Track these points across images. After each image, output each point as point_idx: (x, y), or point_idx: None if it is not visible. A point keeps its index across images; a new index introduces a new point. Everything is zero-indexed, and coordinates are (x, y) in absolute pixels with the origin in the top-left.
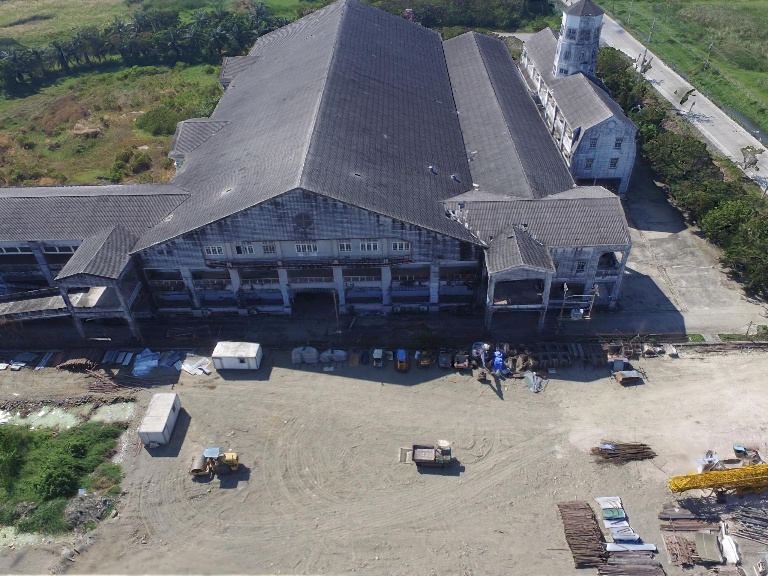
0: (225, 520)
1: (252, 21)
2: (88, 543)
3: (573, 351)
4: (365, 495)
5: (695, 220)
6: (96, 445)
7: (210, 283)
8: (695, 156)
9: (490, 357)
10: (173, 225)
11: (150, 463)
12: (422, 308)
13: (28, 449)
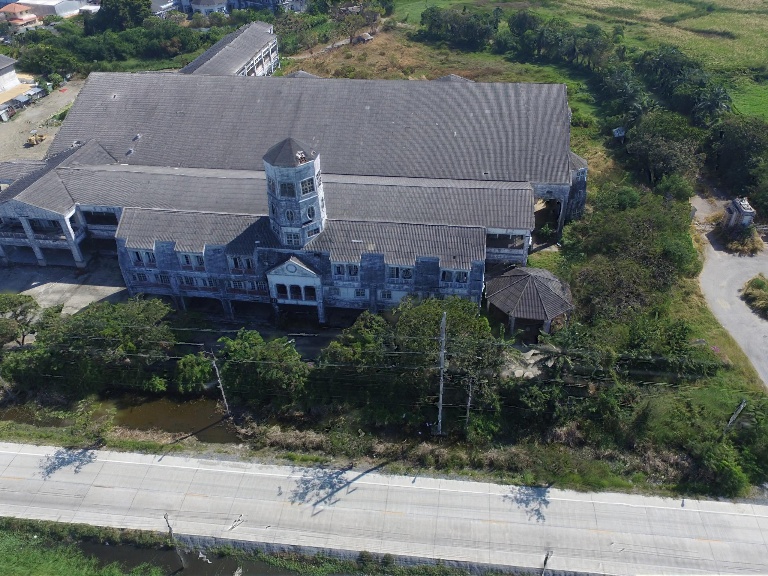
0: None
1: None
2: None
3: None
4: None
5: None
6: None
7: None
8: None
9: None
10: None
11: None
12: None
13: None
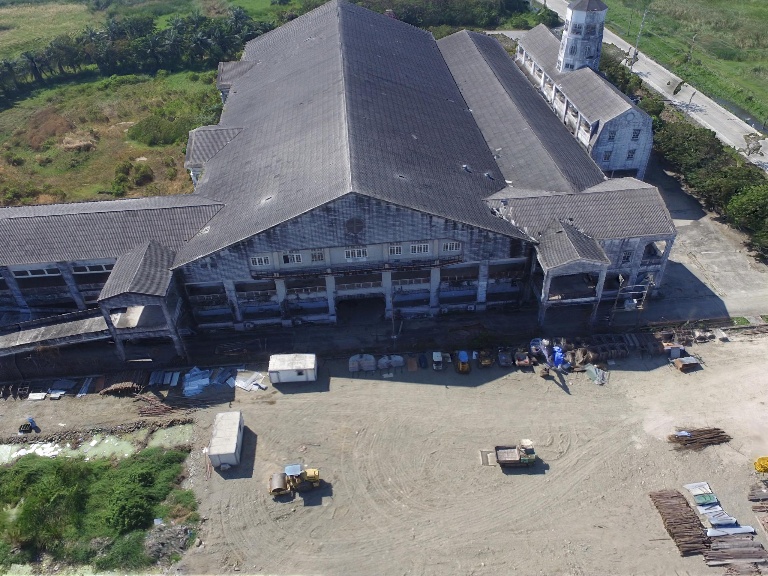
0: (317, 539)
1: (231, 26)
2: (177, 575)
3: (629, 341)
4: (456, 501)
5: (712, 206)
6: (162, 472)
7: (254, 295)
8: (708, 144)
9: (549, 353)
10: (214, 237)
11: (224, 486)
12: (469, 308)
13: (89, 482)
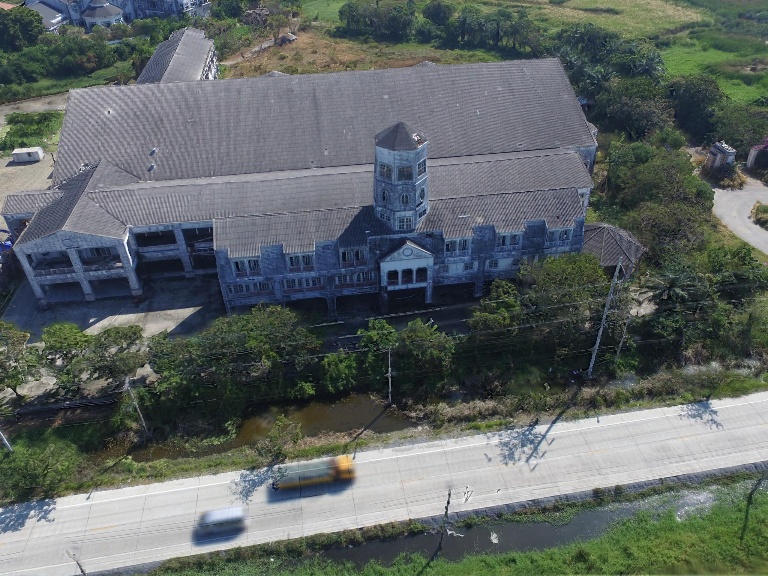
0: None
1: None
2: None
3: None
4: None
5: None
6: None
7: None
8: None
9: None
10: None
11: None
12: None
13: (37, 136)
